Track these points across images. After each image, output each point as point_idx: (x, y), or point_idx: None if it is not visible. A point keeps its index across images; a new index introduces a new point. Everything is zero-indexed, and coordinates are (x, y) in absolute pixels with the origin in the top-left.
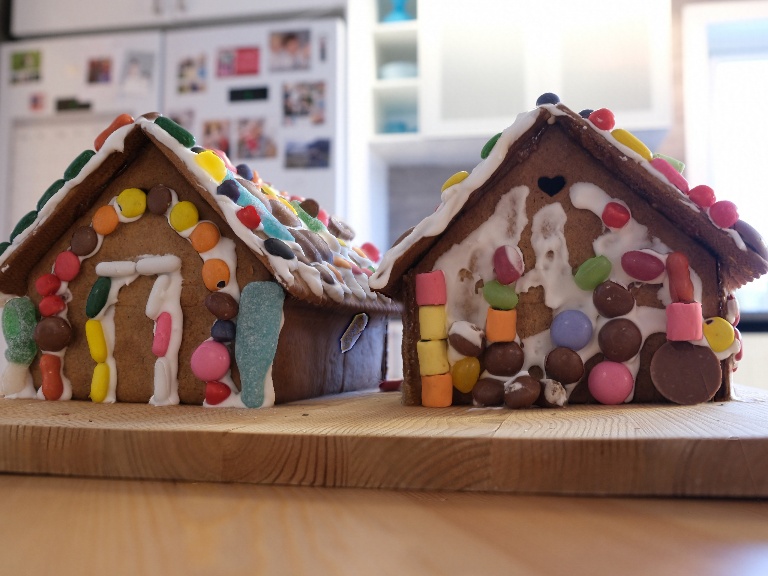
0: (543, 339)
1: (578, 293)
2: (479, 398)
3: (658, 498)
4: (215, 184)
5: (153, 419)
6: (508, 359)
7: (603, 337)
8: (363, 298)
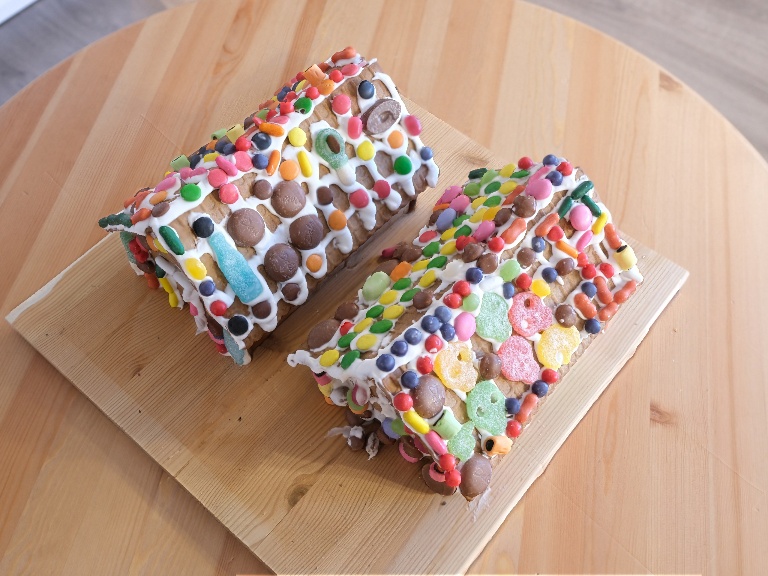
0: None
1: None
2: (346, 416)
3: None
4: (198, 283)
5: (168, 410)
6: (360, 416)
7: None
8: (348, 252)
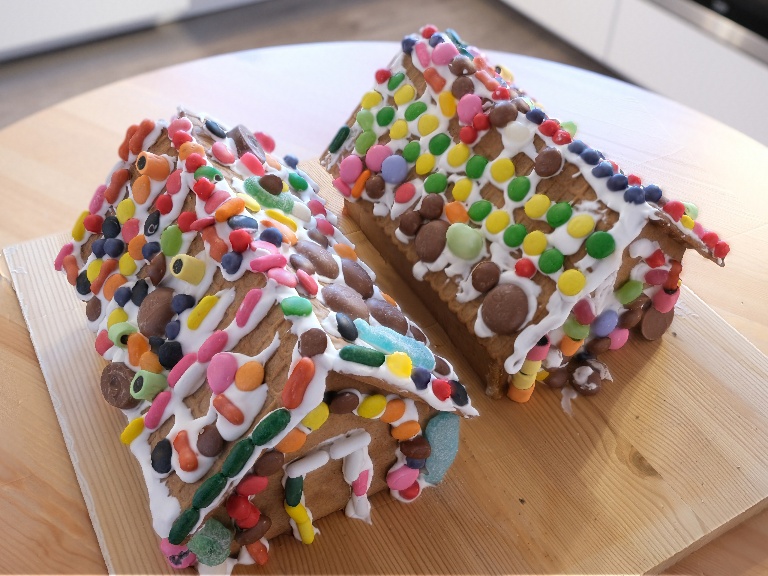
0: None
1: None
2: (553, 386)
3: (765, 514)
4: (412, 381)
5: None
6: None
7: None
8: None
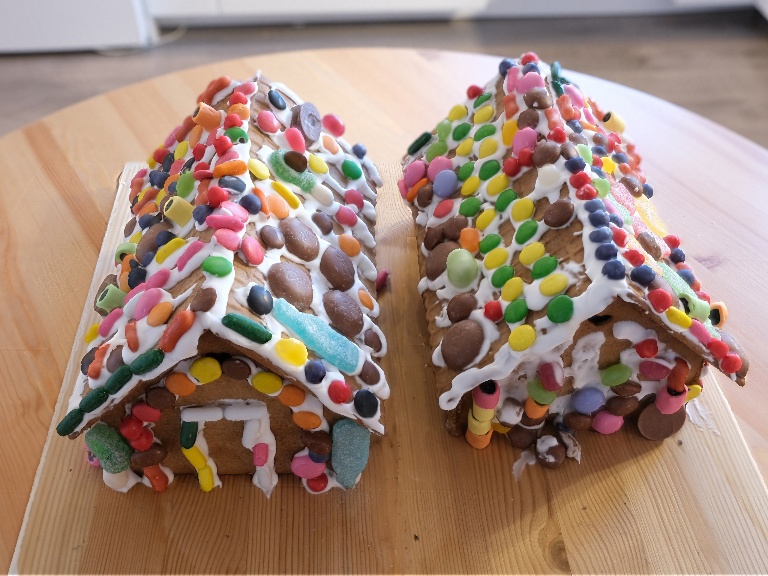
0: (565, 400)
1: (599, 379)
2: (514, 444)
3: None
4: (302, 372)
5: None
6: None
7: (612, 407)
8: None
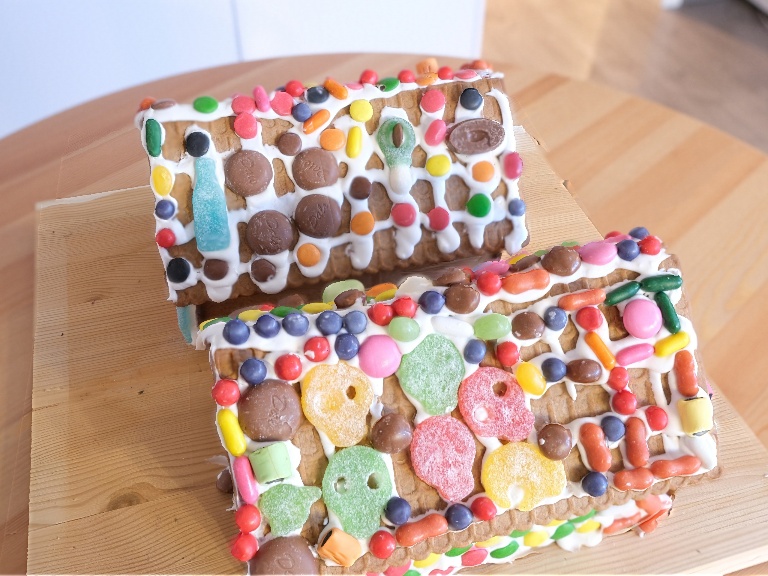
0: None
1: None
2: None
3: None
4: (158, 199)
5: (87, 346)
6: None
7: None
8: (359, 268)
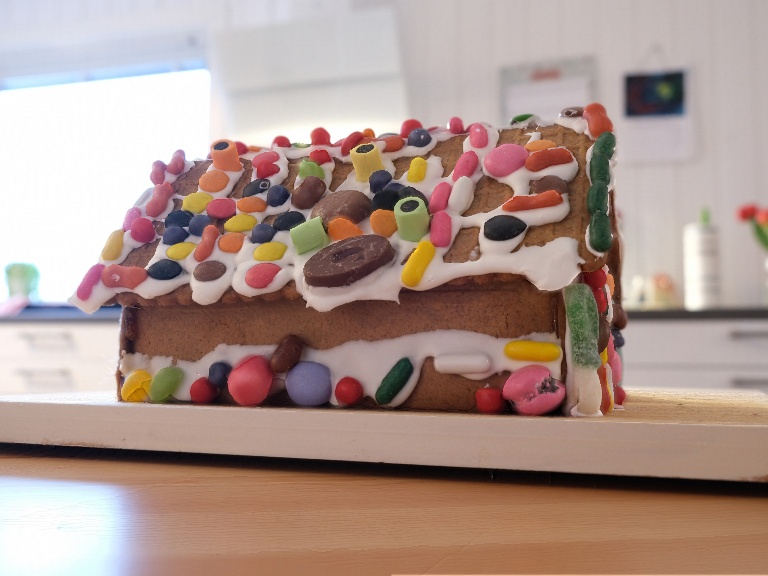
0: None
1: None
2: None
3: None
4: None
5: None
6: None
7: None
8: None
